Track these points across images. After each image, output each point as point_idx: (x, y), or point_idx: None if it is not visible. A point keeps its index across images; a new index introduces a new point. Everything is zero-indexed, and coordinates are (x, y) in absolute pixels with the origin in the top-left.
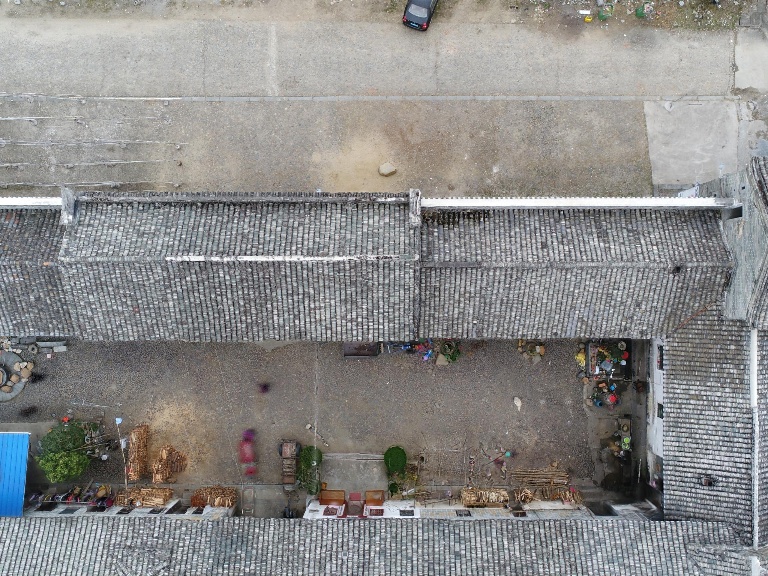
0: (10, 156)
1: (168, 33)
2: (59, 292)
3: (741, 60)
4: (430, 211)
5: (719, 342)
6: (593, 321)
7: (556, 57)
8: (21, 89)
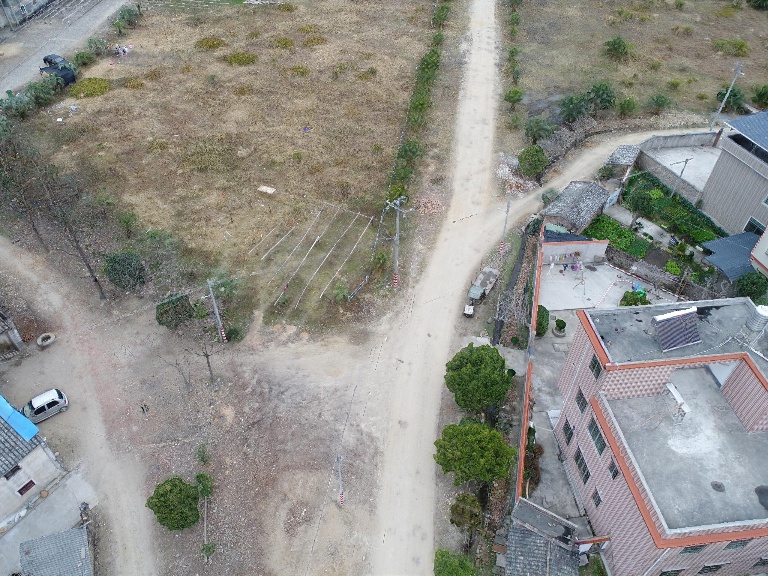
0: (78, 2)
1: (94, 25)
2: None
3: None
4: None
5: None
6: None
7: (7, 88)
8: (99, 5)
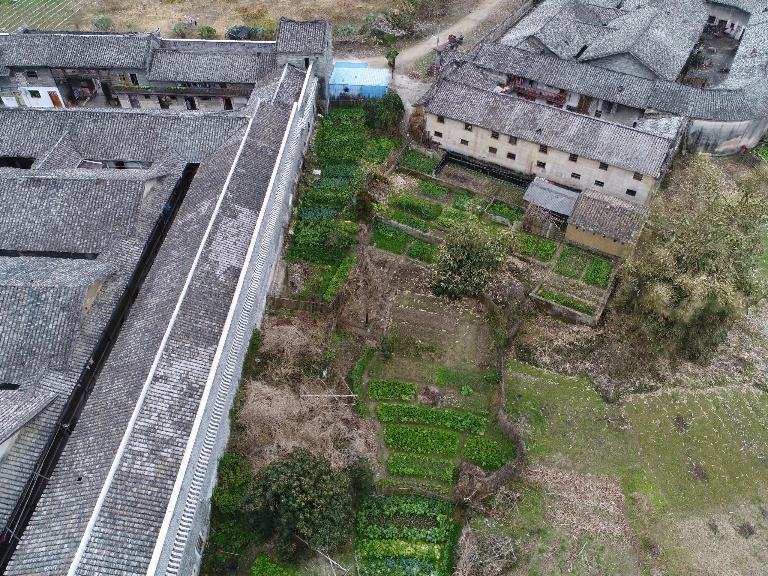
0: None
1: None
2: (1, 58)
3: (333, 63)
4: (165, 41)
5: None
6: (226, 75)
7: None
8: None
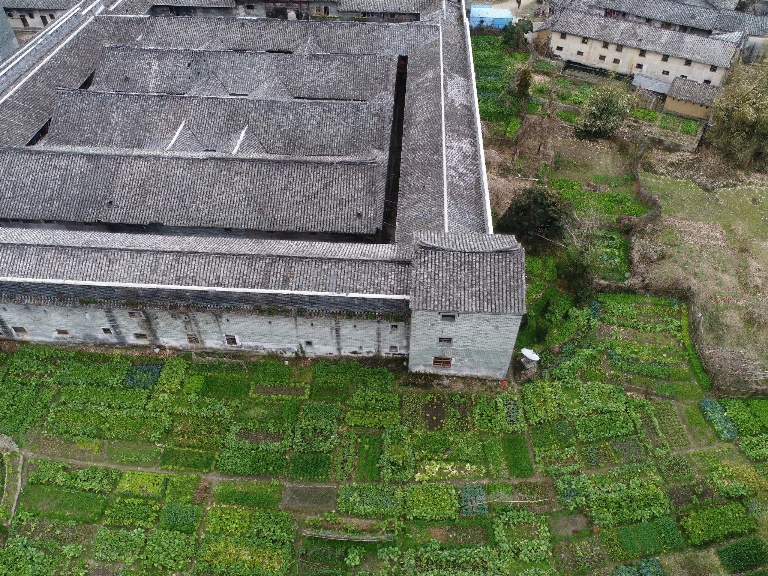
0: None
1: None
2: None
3: None
4: None
5: (435, 6)
6: None
7: None
8: None
